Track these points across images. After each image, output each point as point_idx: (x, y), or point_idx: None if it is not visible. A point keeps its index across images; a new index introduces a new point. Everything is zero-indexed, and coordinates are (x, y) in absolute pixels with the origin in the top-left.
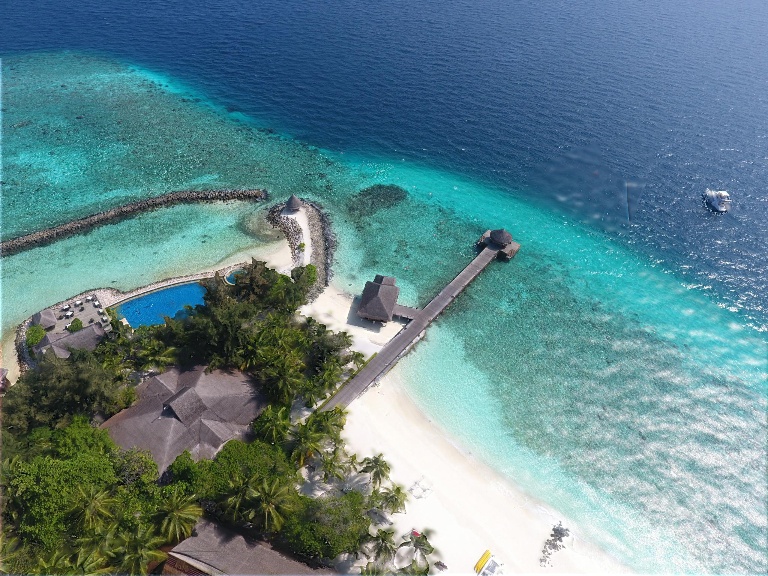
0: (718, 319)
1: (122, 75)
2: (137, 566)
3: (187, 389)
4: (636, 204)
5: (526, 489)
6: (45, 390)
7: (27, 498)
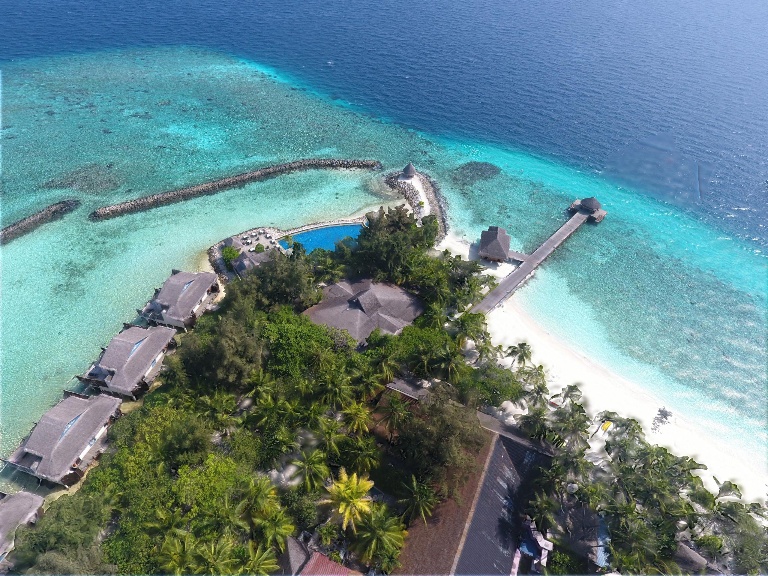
0: None
1: (236, 67)
2: (367, 390)
3: (367, 290)
4: (707, 185)
5: (633, 384)
6: (271, 279)
7: (272, 348)
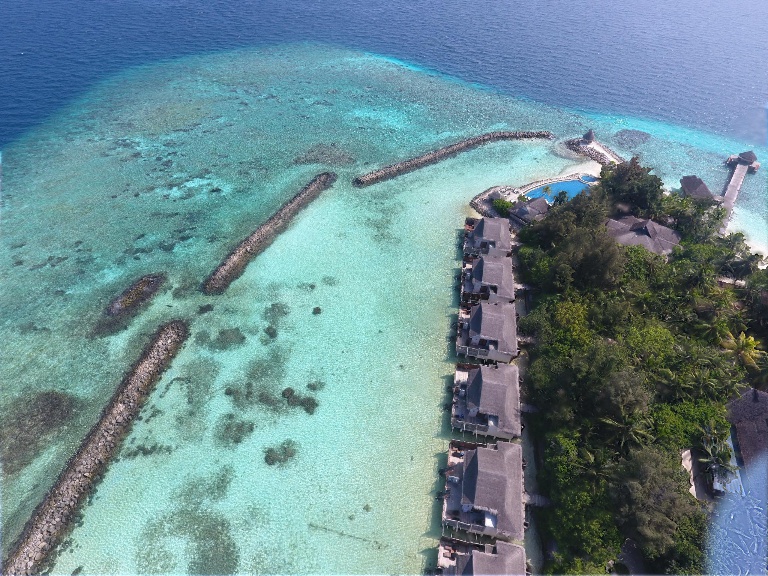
0: None
1: (366, 59)
2: None
3: None
4: None
5: None
6: (584, 213)
7: None
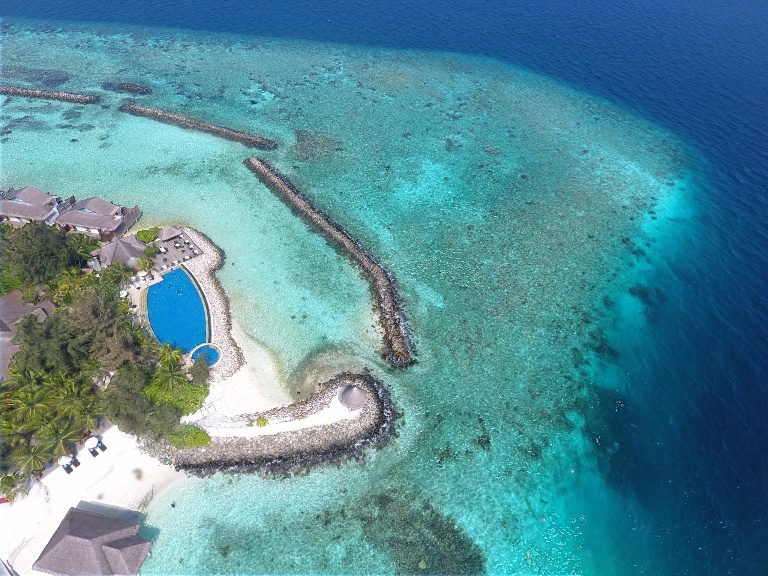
0: None
1: (649, 179)
2: None
3: None
4: None
5: None
6: None
7: None
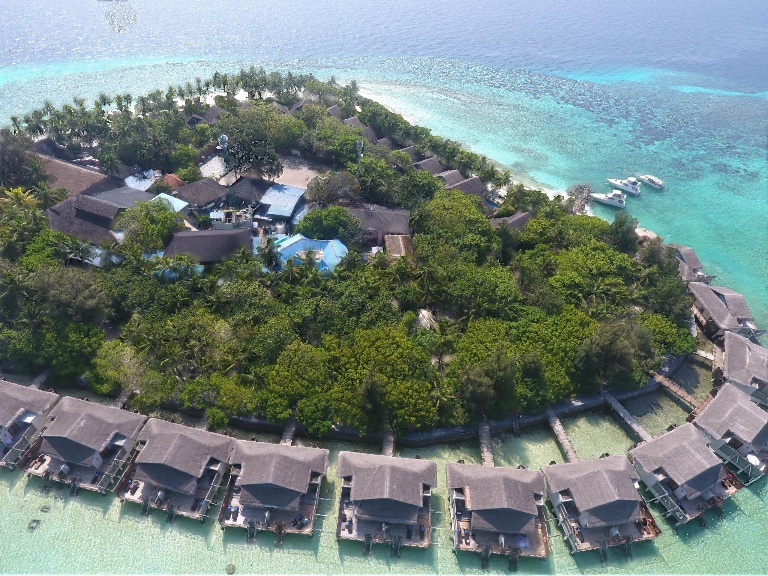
0: (8, 72)
1: None
2: None
3: None
4: None
5: None
6: None
7: None
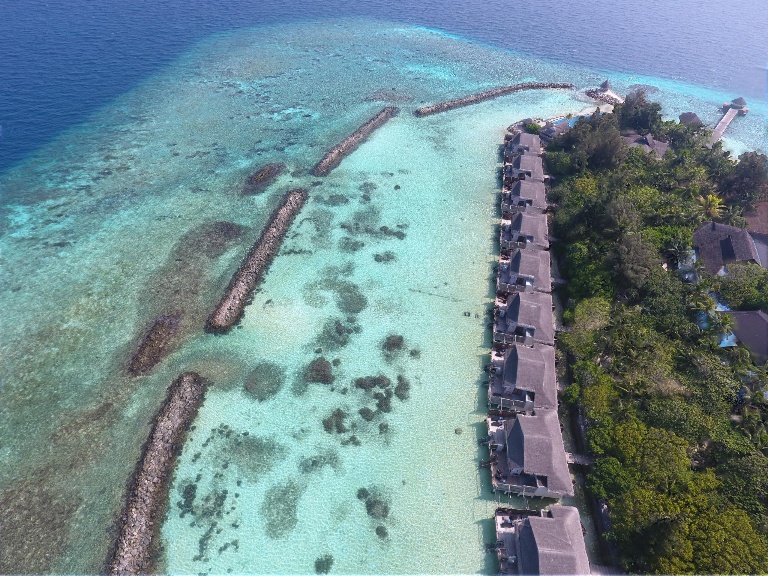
0: None
1: (413, 29)
2: None
3: None
4: None
5: None
6: (598, 125)
7: None
